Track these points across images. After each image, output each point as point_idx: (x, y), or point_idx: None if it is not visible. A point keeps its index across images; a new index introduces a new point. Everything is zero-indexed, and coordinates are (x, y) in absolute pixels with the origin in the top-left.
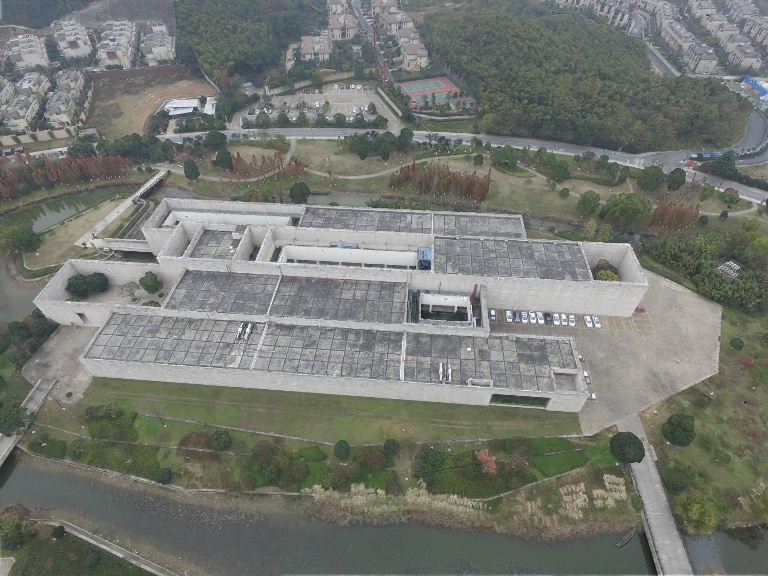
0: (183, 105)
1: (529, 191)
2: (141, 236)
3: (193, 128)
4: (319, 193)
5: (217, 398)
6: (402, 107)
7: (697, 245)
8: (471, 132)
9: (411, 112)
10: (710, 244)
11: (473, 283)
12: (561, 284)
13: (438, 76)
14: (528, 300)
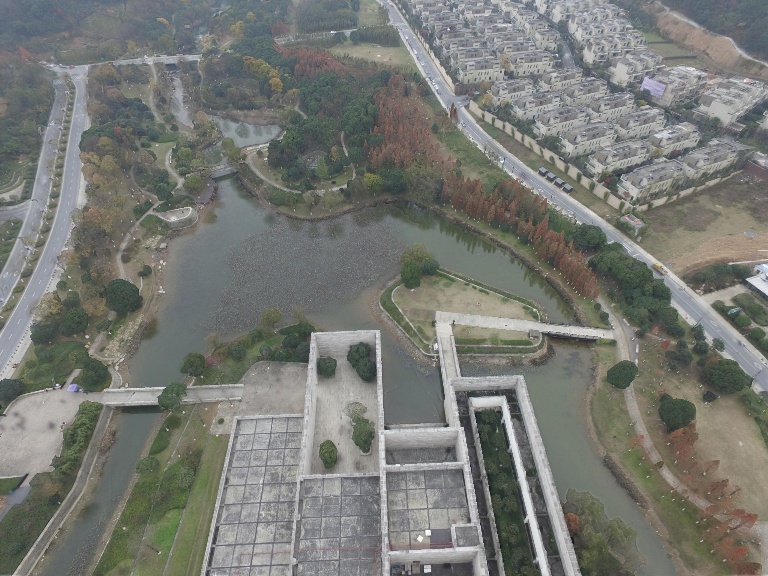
0: None
1: None
2: (477, 369)
3: (741, 324)
4: None
5: None
6: None
7: None
8: None
9: None
10: None
11: None
12: None
13: None
14: None
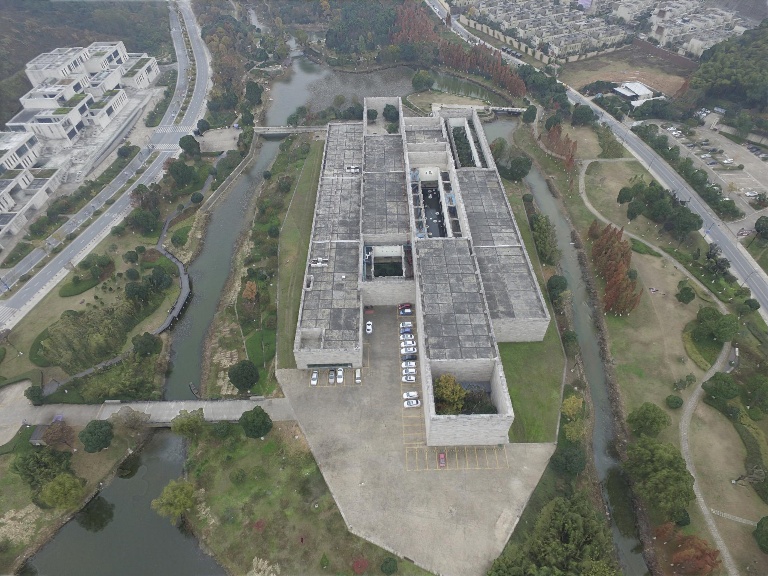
0: (633, 88)
1: (658, 361)
2: None
3: (603, 104)
4: (552, 191)
5: (315, 182)
6: None
7: None
8: None
9: None
10: None
11: None
12: None
13: None
14: None
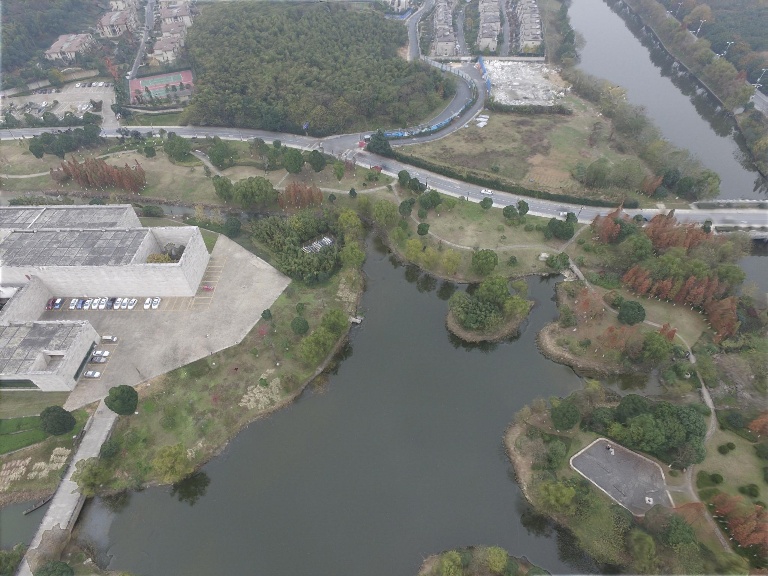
0: None
1: (188, 180)
2: None
3: None
4: None
5: None
6: (121, 103)
7: (286, 223)
8: (179, 124)
9: (127, 107)
10: (299, 222)
11: (23, 274)
12: (101, 269)
13: (182, 70)
14: (89, 287)
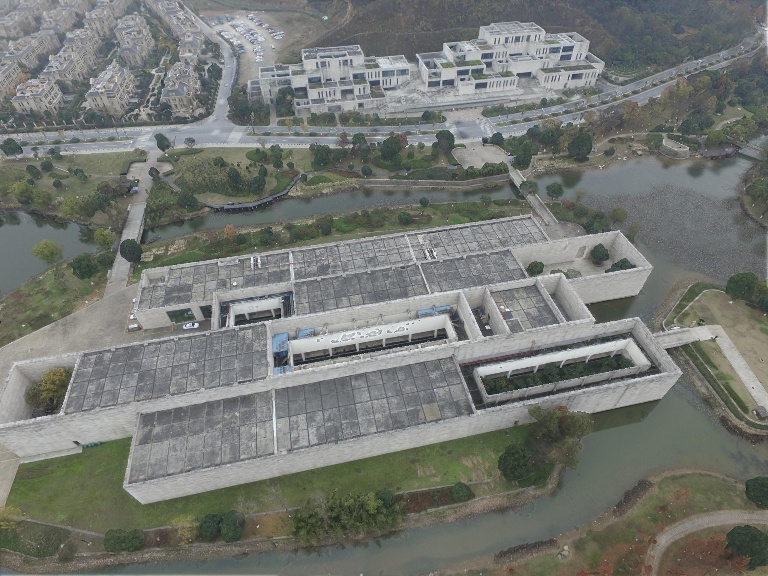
0: None
1: None
2: None
3: None
4: (516, 548)
5: None
6: None
7: None
8: None
9: None
10: None
11: None
12: None
13: None
14: None
